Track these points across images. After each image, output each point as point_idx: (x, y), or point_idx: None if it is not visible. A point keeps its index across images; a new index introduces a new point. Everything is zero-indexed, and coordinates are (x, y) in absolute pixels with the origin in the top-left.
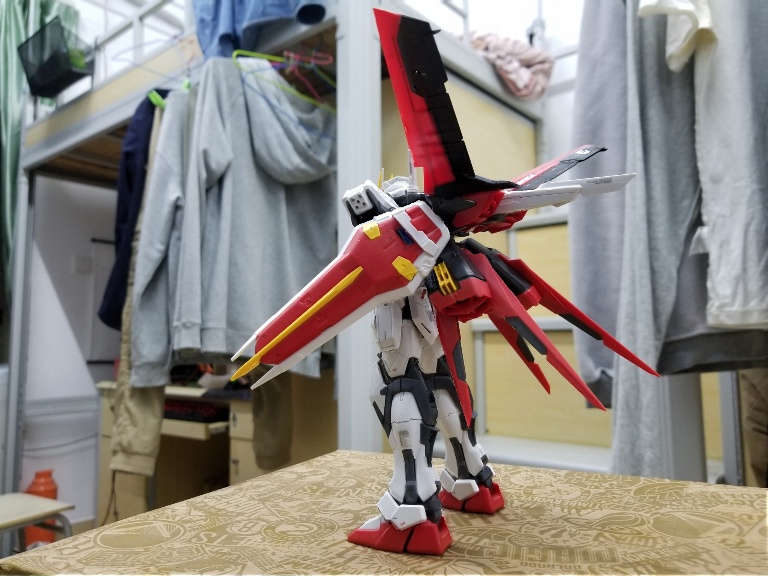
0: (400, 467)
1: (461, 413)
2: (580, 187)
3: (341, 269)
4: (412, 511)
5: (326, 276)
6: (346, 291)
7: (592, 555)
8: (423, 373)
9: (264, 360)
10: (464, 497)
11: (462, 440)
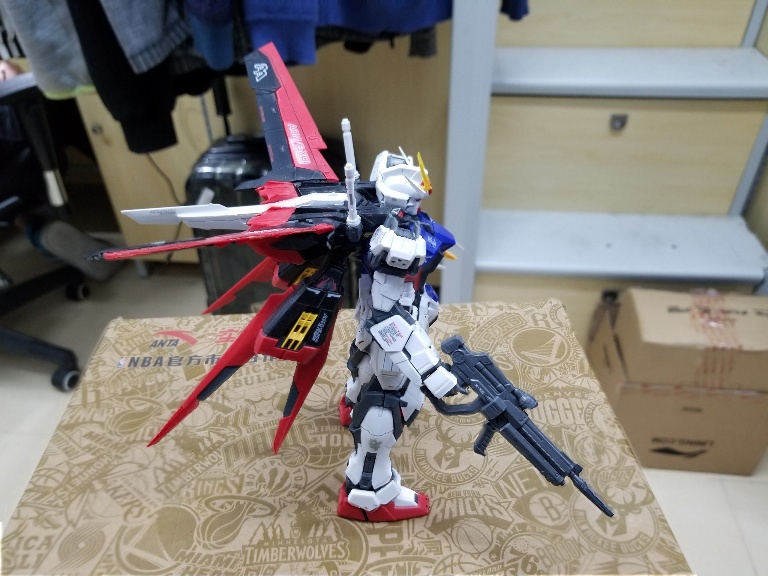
0: None
1: None
2: (180, 214)
3: None
4: None
5: None
6: None
7: (242, 450)
8: None
9: None
10: None
11: None
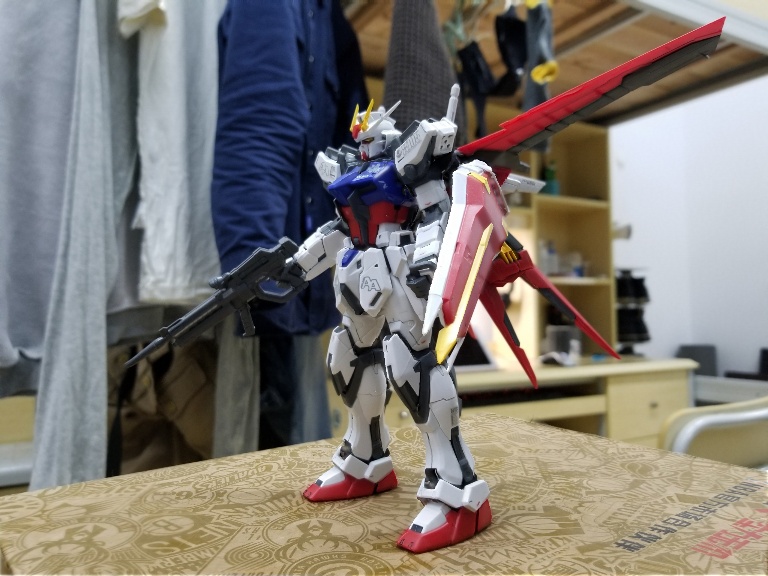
0: (447, 448)
1: (387, 388)
2: (520, 183)
3: (480, 222)
4: (484, 487)
5: (473, 228)
6: (488, 249)
7: (523, 482)
8: (358, 347)
9: (458, 332)
10: (381, 478)
11: (381, 417)
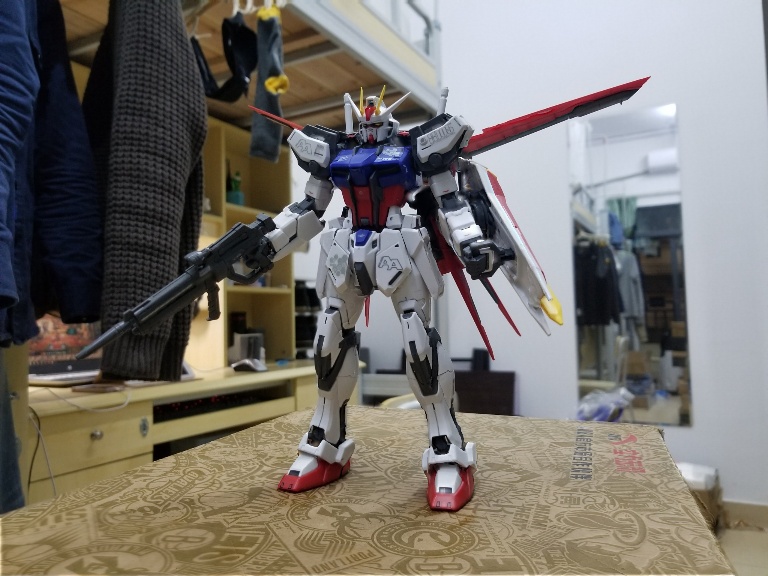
0: None
1: None
2: None
3: None
4: None
5: None
6: None
7: None
8: (344, 329)
9: None
10: (347, 460)
11: None
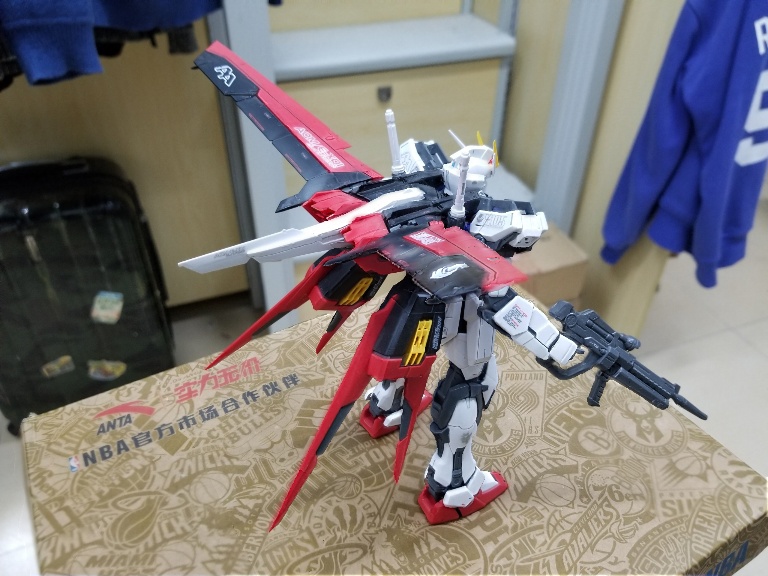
0: None
1: None
2: None
3: None
4: None
5: None
6: None
7: None
8: None
9: None
10: None
11: None
